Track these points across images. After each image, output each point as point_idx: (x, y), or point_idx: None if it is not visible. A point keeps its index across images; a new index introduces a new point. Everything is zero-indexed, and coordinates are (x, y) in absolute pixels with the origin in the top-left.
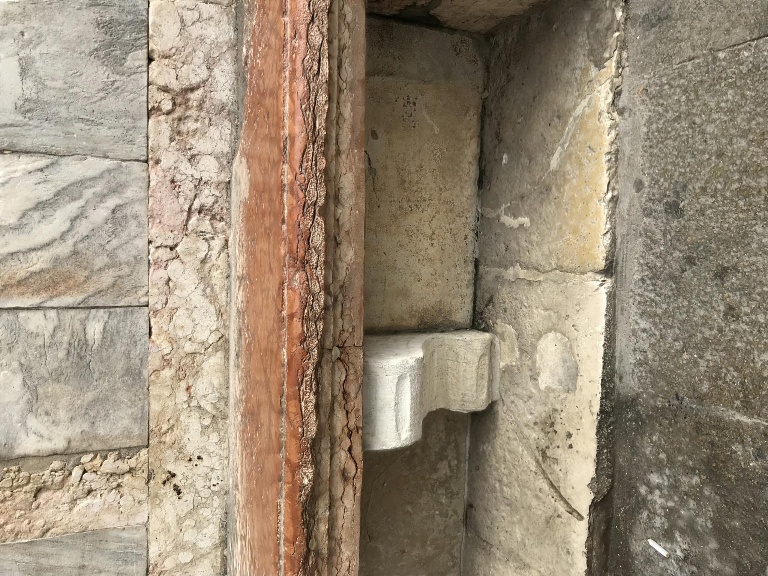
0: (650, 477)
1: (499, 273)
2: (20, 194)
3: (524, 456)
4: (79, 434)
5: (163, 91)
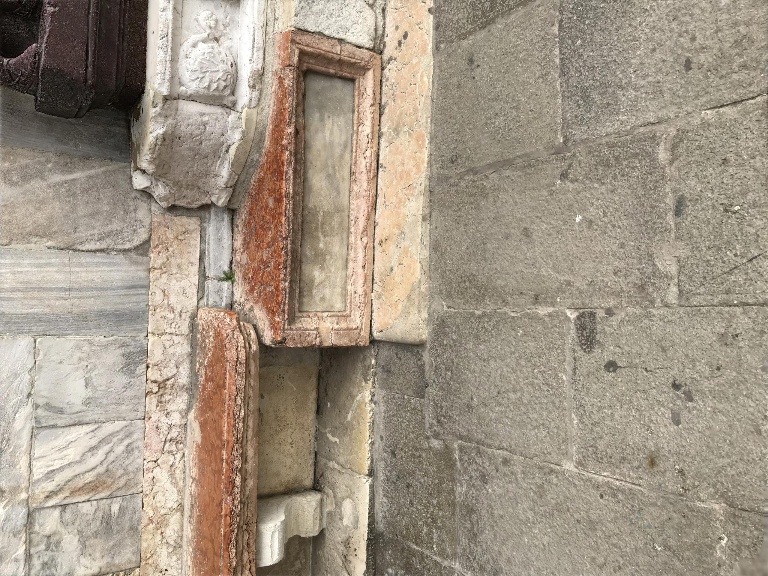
0: (388, 570)
1: (326, 462)
2: (82, 445)
3: (337, 558)
4: (106, 564)
5: (154, 382)
